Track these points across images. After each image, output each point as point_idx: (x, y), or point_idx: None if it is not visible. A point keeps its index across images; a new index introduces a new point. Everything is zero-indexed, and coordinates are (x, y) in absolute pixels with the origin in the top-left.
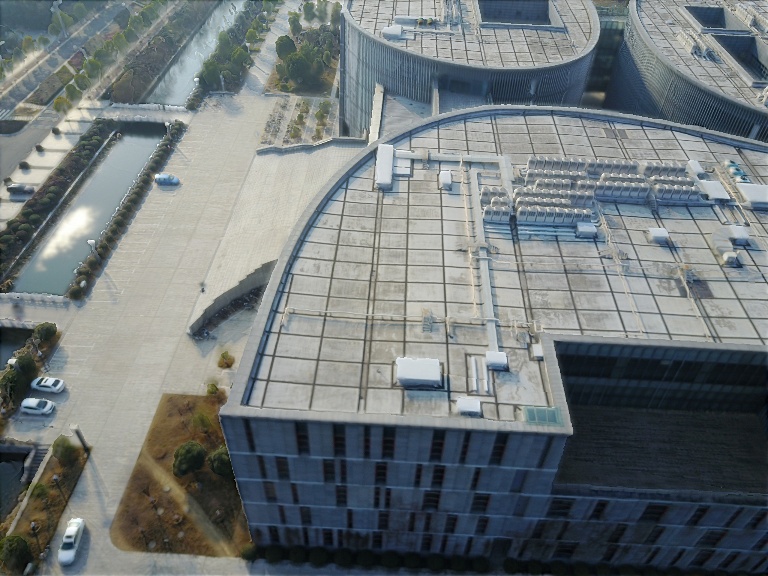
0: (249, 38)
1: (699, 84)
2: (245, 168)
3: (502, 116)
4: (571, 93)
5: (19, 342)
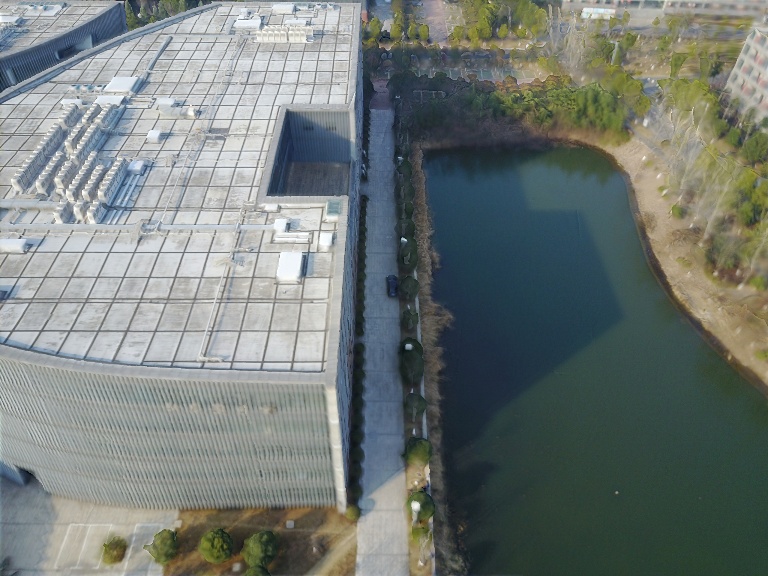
0: None
1: None
2: None
3: None
4: None
5: None
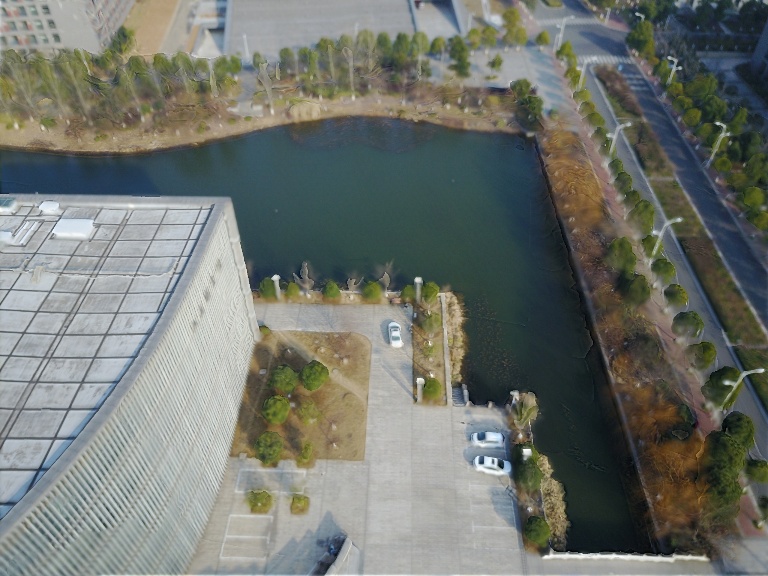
0: None
1: None
2: None
3: None
4: None
5: (579, 546)
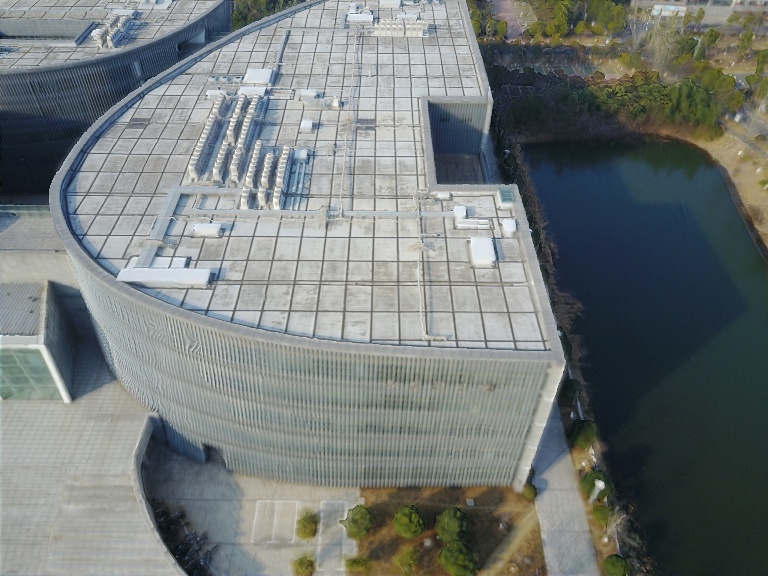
0: None
1: (65, 65)
2: None
3: (71, 187)
4: None
5: None
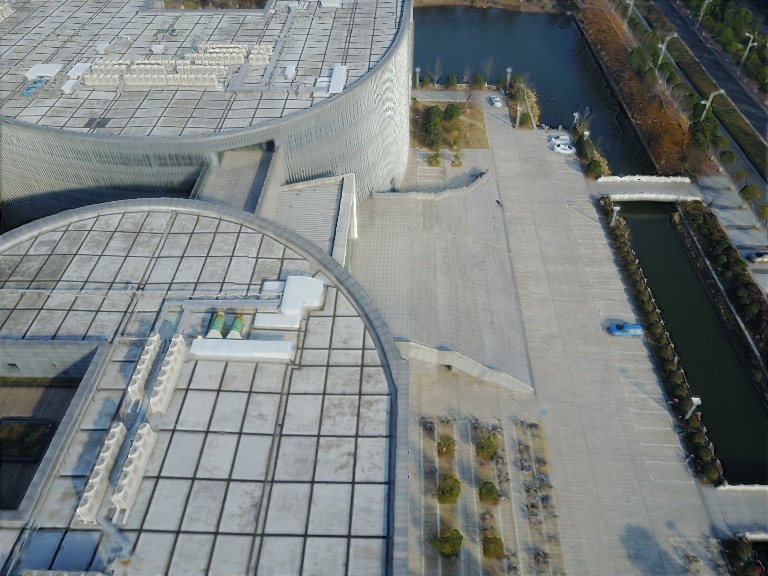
0: None
1: None
2: (536, 363)
3: None
4: None
5: None
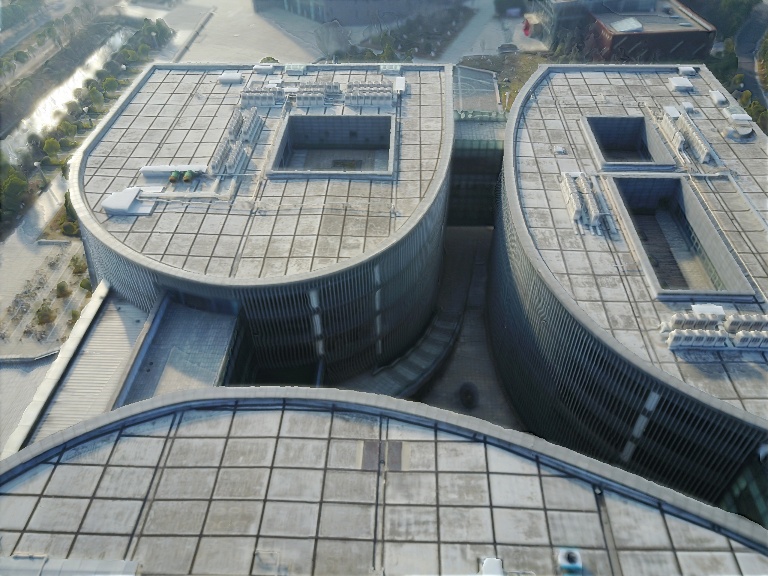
0: (48, 150)
1: (565, 305)
2: None
3: (195, 413)
4: (391, 288)
5: None
